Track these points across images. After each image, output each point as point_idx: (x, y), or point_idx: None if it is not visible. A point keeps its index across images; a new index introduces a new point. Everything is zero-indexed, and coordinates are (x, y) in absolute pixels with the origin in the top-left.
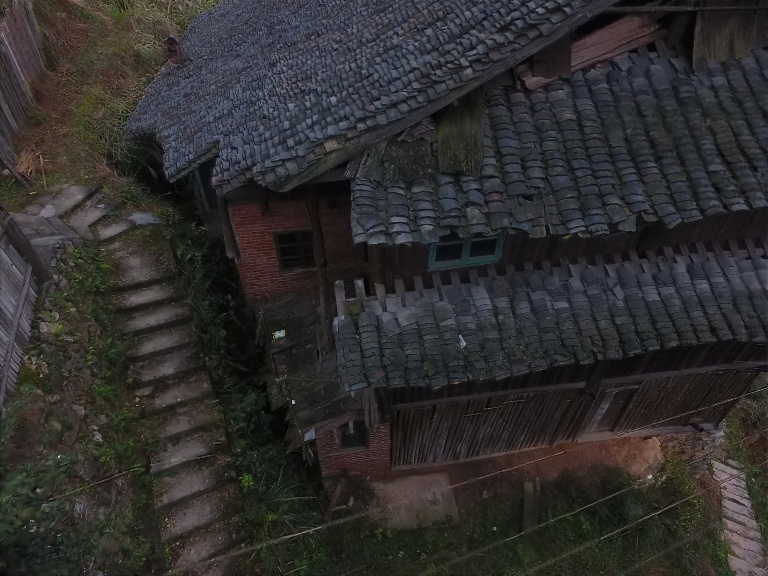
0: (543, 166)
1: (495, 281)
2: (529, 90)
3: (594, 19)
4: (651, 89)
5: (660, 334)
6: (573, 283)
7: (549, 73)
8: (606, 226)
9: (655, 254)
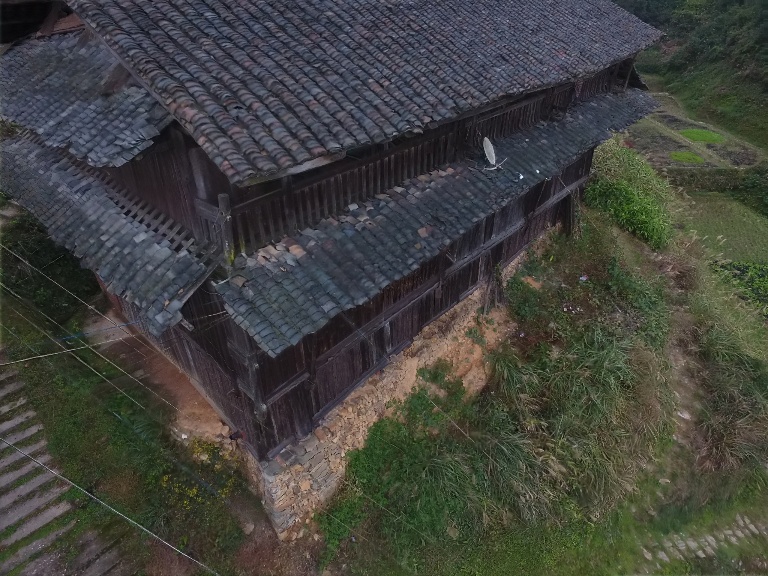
0: None
1: None
2: None
3: (67, 7)
4: None
5: None
6: None
7: (43, 31)
8: None
9: (92, 173)
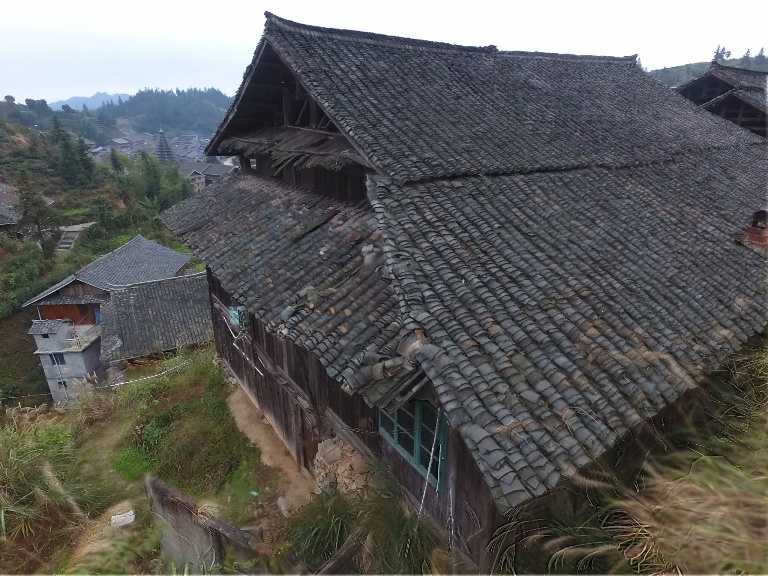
0: None
1: None
2: None
3: None
4: None
5: None
6: None
7: None
8: None
9: None
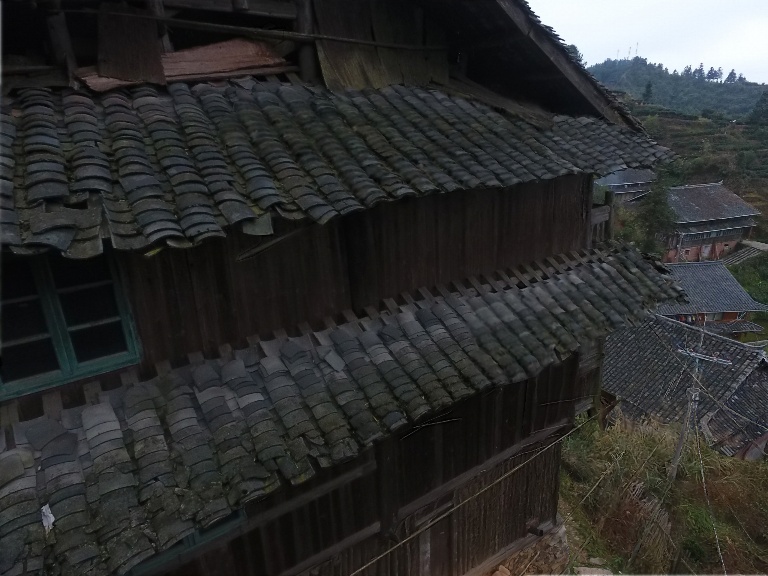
0: (111, 168)
1: (130, 390)
2: (96, 93)
3: (187, 31)
4: (284, 105)
5: (403, 403)
6: (267, 364)
7: (127, 76)
8: (216, 226)
9: (376, 309)
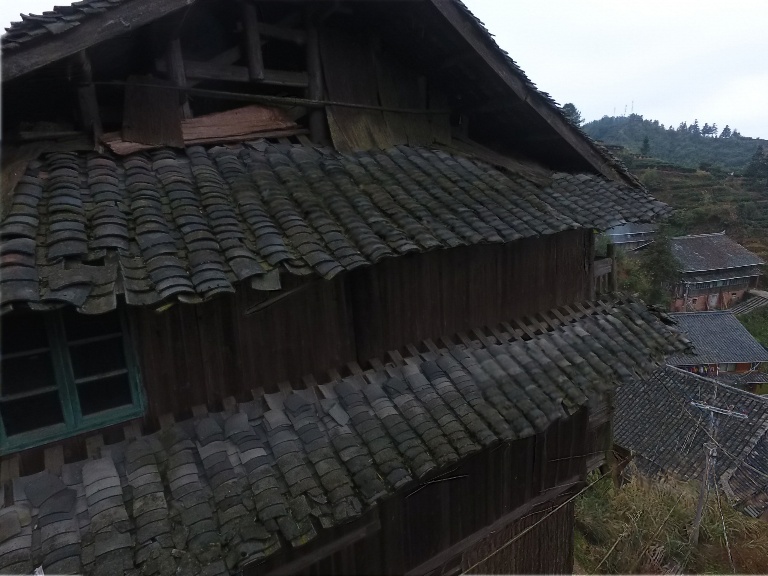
0: (129, 226)
1: (132, 444)
2: (119, 156)
3: (206, 100)
4: (294, 165)
5: (407, 459)
6: (270, 418)
7: (148, 140)
8: (226, 282)
9: (381, 361)
